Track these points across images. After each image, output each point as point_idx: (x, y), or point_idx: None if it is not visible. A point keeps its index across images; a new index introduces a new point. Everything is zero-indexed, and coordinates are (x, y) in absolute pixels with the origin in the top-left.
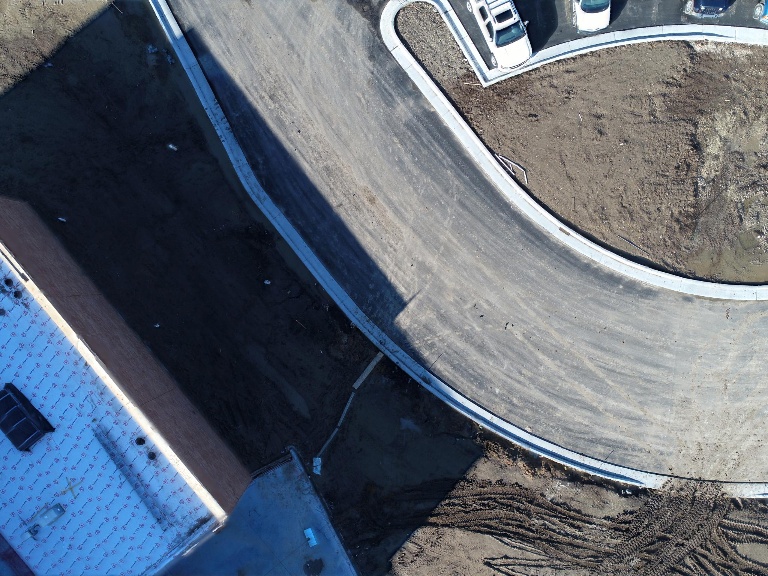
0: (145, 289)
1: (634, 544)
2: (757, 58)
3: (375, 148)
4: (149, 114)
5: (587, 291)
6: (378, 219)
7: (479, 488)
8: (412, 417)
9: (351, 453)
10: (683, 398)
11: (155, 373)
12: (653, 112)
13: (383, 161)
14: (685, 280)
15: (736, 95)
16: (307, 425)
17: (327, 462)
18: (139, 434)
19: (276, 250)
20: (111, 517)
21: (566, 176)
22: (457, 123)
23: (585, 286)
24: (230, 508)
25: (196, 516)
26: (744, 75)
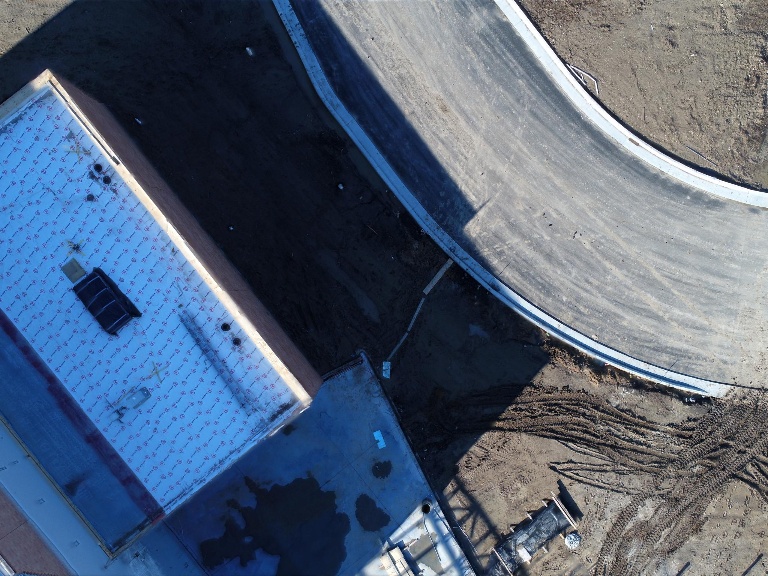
0: (219, 192)
1: (697, 451)
2: None
3: (448, 56)
4: (224, 19)
5: (655, 202)
6: (450, 127)
7: (546, 394)
8: (481, 323)
9: (420, 358)
10: (747, 309)
11: (231, 272)
12: (724, 24)
13: (455, 70)
14: (752, 192)
15: None
16: (377, 329)
17: (396, 366)
18: (225, 320)
19: (348, 157)
20: (196, 401)
21: (637, 86)
22: (529, 33)
23: (653, 197)
24: (313, 395)
25: (280, 402)
26: None
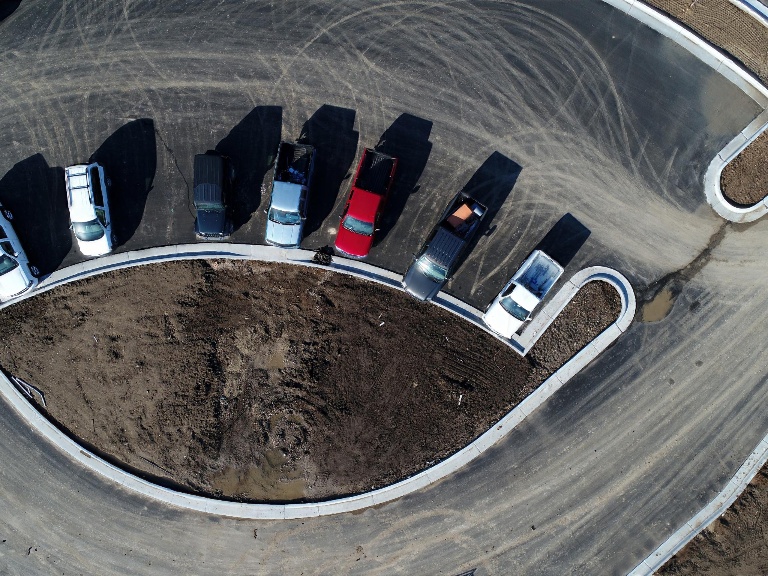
0: None
1: None
2: (276, 275)
3: None
4: None
5: (111, 513)
6: None
7: None
8: None
9: None
10: None
11: None
12: (170, 332)
13: None
14: (210, 501)
15: (257, 312)
16: None
17: None
18: None
19: None
20: None
21: (83, 399)
22: None
23: (109, 508)
24: None
25: None
26: (264, 292)
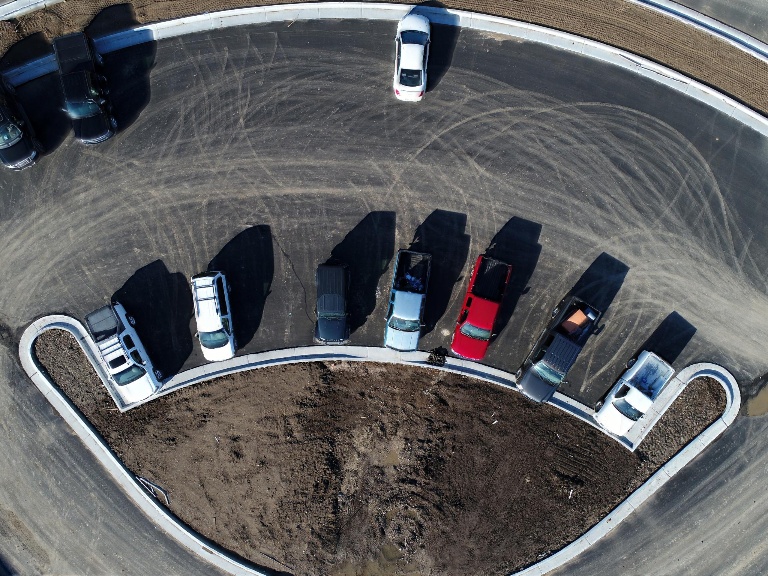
0: None
1: None
2: (391, 375)
3: (18, 473)
4: None
5: None
6: (23, 543)
7: None
8: None
9: None
10: None
11: None
12: (289, 432)
13: (27, 486)
14: None
15: (372, 411)
16: None
17: None
18: None
19: None
20: None
21: (205, 497)
22: (98, 446)
23: None
24: None
25: None
26: (379, 392)
